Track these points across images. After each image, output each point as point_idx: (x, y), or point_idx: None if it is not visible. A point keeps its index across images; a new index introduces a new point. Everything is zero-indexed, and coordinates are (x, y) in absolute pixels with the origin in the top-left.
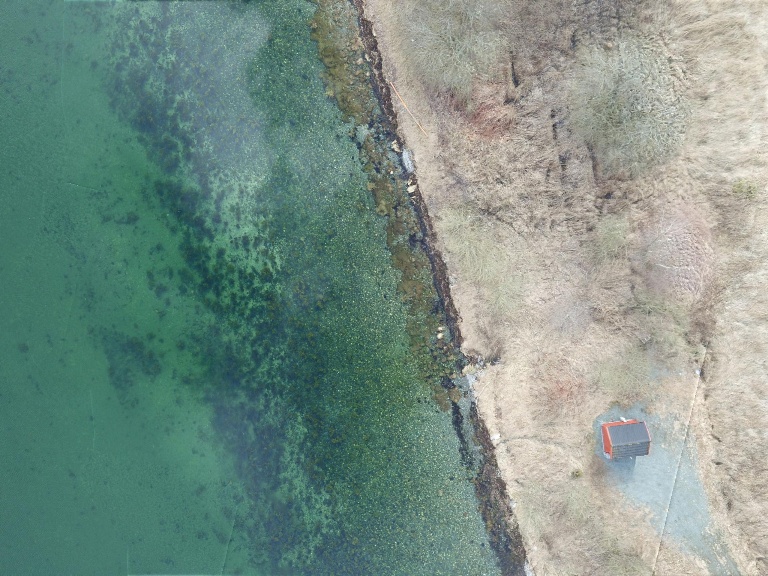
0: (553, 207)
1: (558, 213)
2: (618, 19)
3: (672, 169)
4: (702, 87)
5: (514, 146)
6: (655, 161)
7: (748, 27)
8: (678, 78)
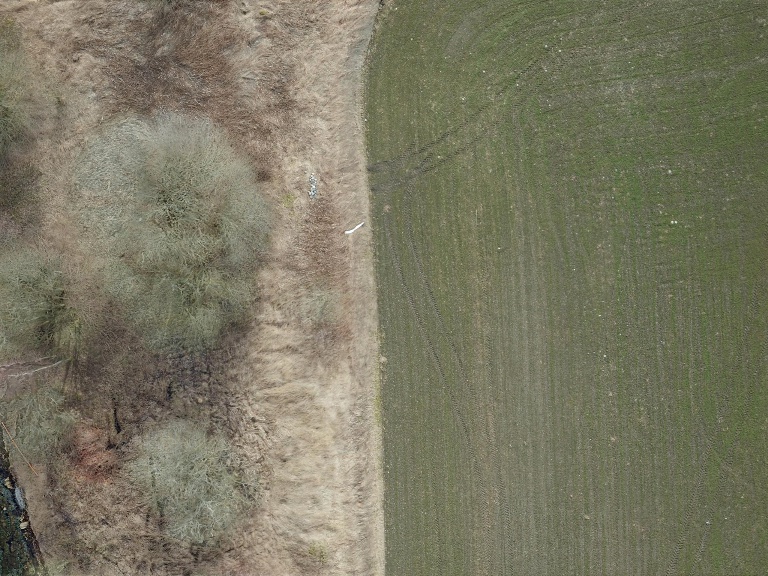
0: (153, 551)
1: (157, 558)
2: (209, 375)
3: (259, 523)
4: (281, 449)
5: (117, 490)
6: (244, 514)
7: (318, 398)
8: (261, 437)
